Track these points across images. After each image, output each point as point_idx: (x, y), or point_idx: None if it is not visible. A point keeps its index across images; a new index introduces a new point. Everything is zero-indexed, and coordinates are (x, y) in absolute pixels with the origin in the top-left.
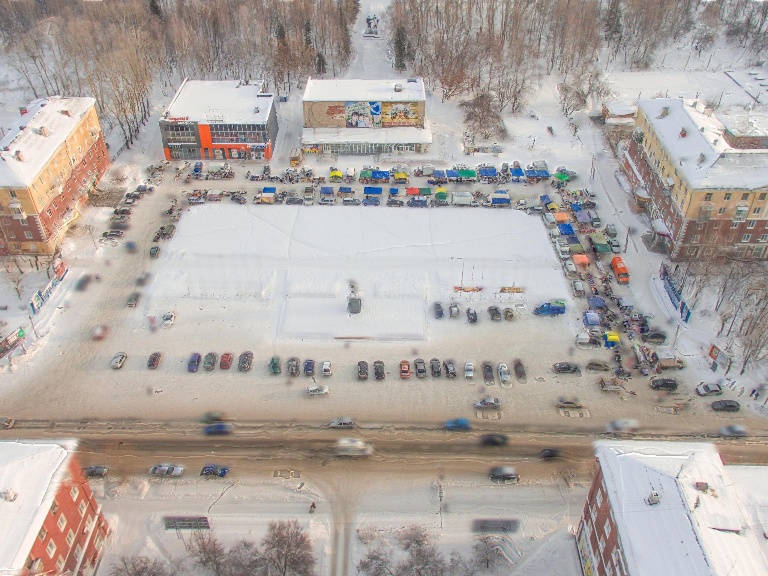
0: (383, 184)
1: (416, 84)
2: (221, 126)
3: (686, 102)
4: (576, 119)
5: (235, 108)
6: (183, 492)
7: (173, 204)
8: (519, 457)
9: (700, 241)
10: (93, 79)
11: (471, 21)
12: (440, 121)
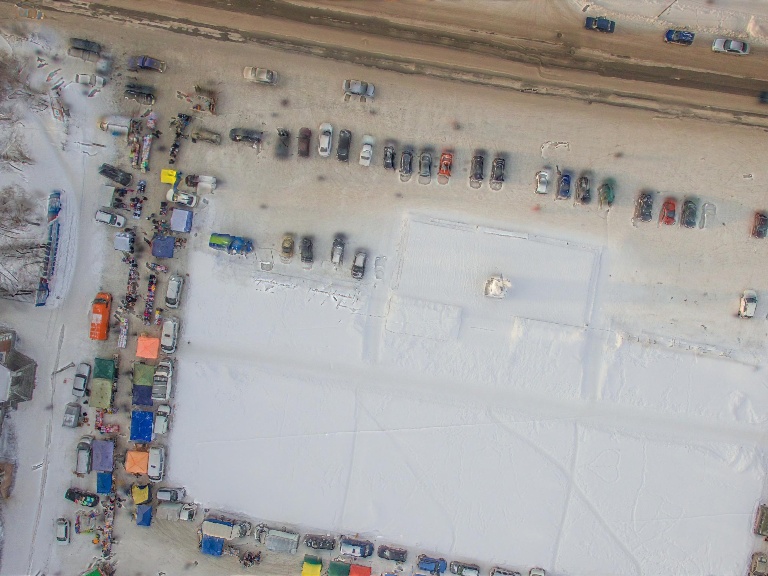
0: None
1: None
2: None
3: None
4: None
5: None
6: (712, 16)
7: None
8: (343, 25)
9: None
10: None
11: None
12: None
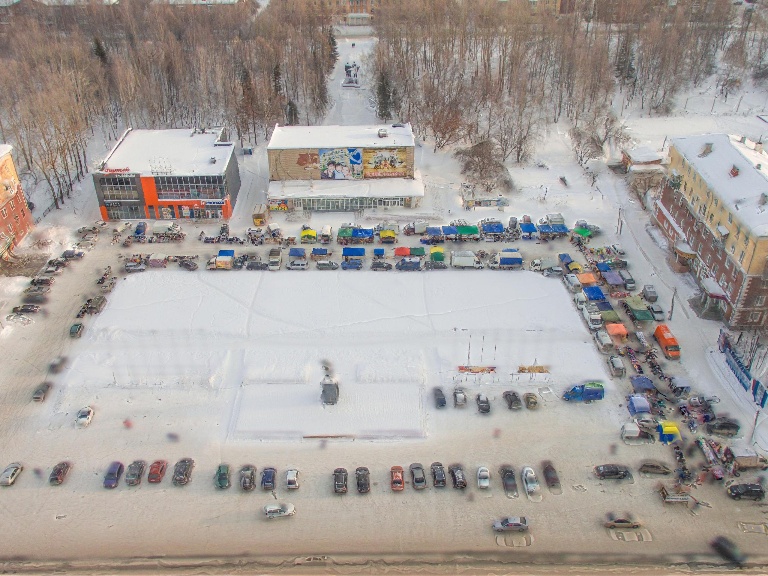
0: (366, 244)
1: (403, 129)
2: (168, 178)
3: (732, 137)
4: (592, 168)
5: (187, 158)
6: None
7: (105, 272)
8: None
9: (765, 303)
10: (19, 129)
11: (464, 64)
12: (432, 173)
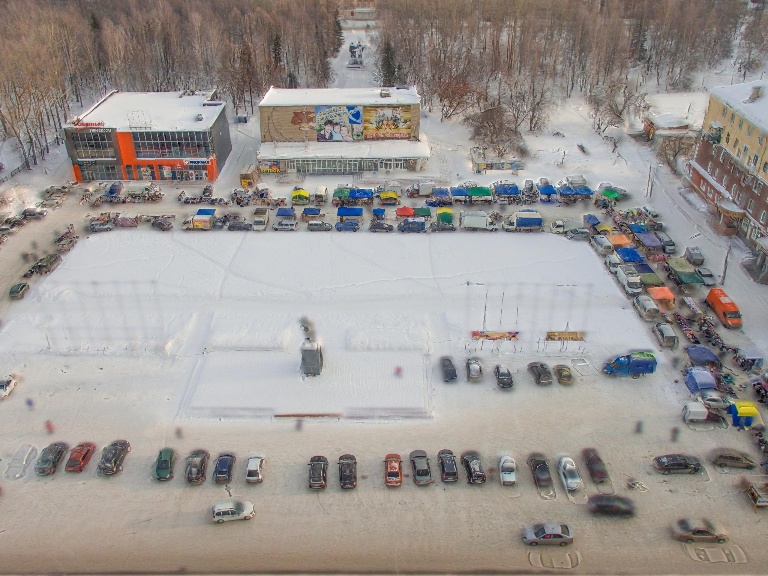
0: (365, 206)
1: (408, 90)
2: (148, 134)
3: None
4: (612, 136)
5: (171, 116)
6: None
7: (67, 230)
8: None
9: None
10: None
11: (472, 40)
12: (439, 140)
